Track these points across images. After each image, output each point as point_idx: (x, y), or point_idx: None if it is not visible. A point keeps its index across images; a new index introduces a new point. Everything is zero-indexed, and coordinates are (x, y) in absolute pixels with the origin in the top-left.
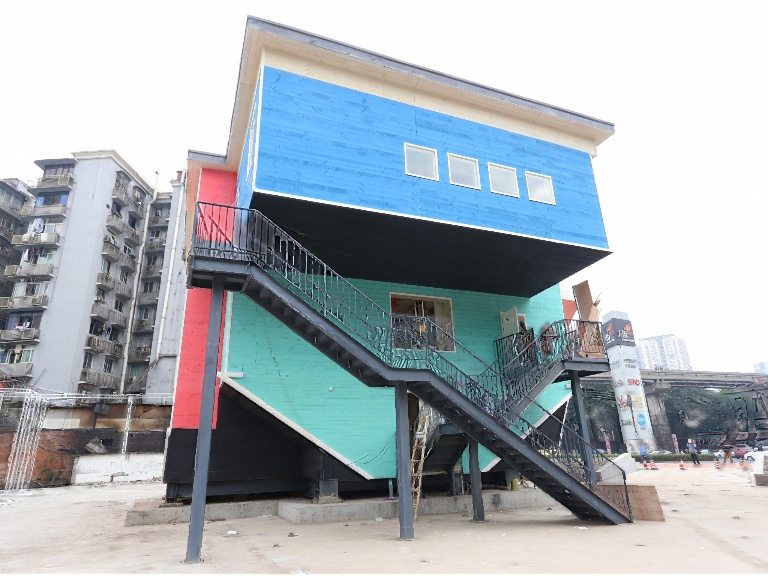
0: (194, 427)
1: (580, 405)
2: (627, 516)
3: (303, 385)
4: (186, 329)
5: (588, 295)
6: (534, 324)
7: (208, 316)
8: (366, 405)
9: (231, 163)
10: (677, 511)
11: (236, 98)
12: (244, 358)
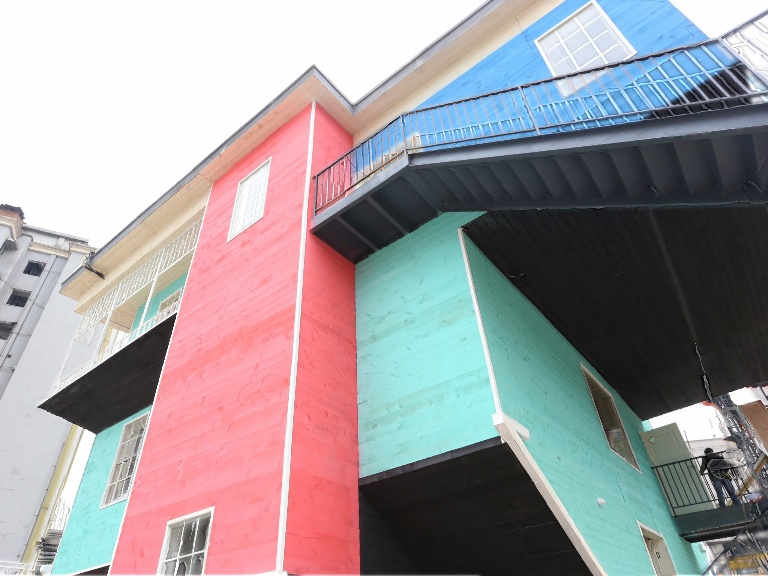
0: (324, 574)
1: None
2: None
3: (577, 484)
4: (303, 329)
5: (767, 418)
6: None
7: (333, 319)
8: (630, 544)
9: (363, 115)
10: None
11: (490, 8)
12: (512, 399)
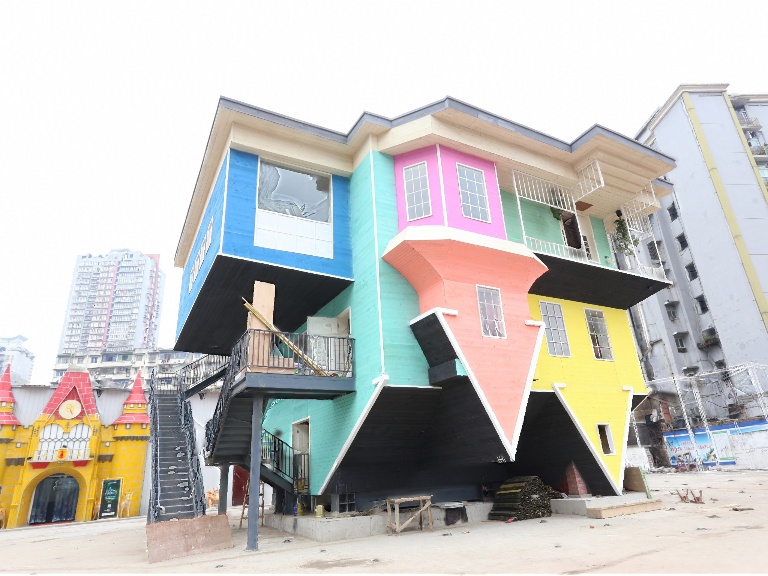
0: None
1: (252, 429)
2: (183, 554)
3: None
4: None
5: (256, 298)
6: (356, 313)
7: None
8: None
9: None
10: (215, 567)
11: None
12: None
